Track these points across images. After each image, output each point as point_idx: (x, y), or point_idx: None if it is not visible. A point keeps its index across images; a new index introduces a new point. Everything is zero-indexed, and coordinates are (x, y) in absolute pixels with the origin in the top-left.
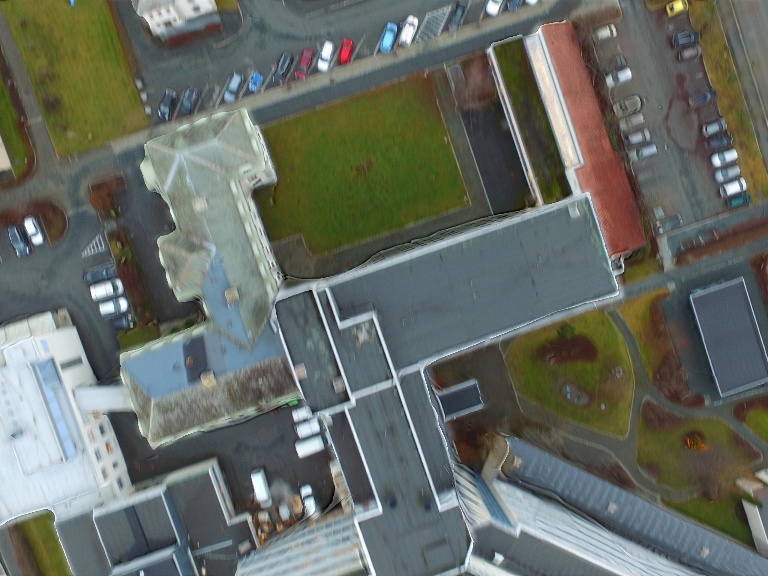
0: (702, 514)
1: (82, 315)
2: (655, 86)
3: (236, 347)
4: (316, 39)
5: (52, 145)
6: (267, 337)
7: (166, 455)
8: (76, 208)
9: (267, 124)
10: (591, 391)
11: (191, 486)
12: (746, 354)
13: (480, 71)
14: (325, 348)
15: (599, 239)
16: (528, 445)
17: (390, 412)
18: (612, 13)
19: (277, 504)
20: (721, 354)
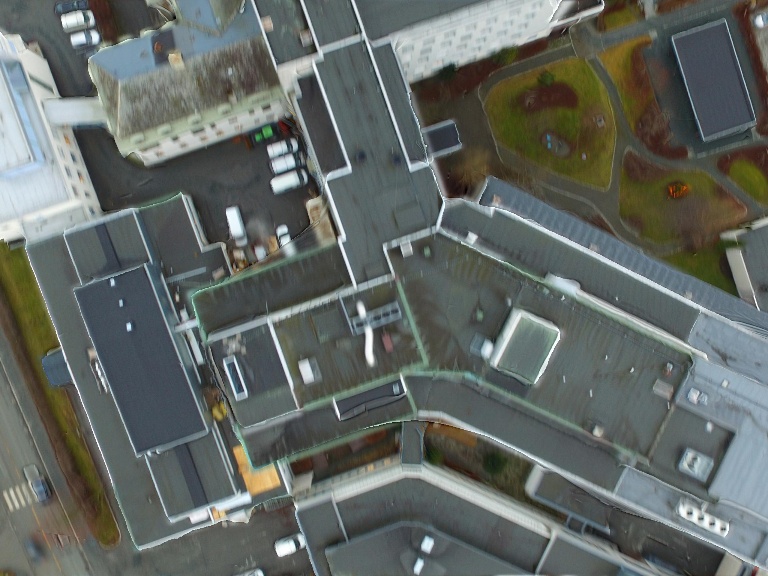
0: (686, 268)
1: (53, 49)
2: None
3: (205, 35)
4: None
5: None
6: (236, 23)
7: (140, 193)
8: None
9: None
10: (572, 140)
11: (164, 211)
12: (729, 97)
13: None
14: (292, 1)
15: None
16: (507, 185)
17: (359, 68)
18: None
19: (253, 244)
20: (703, 97)
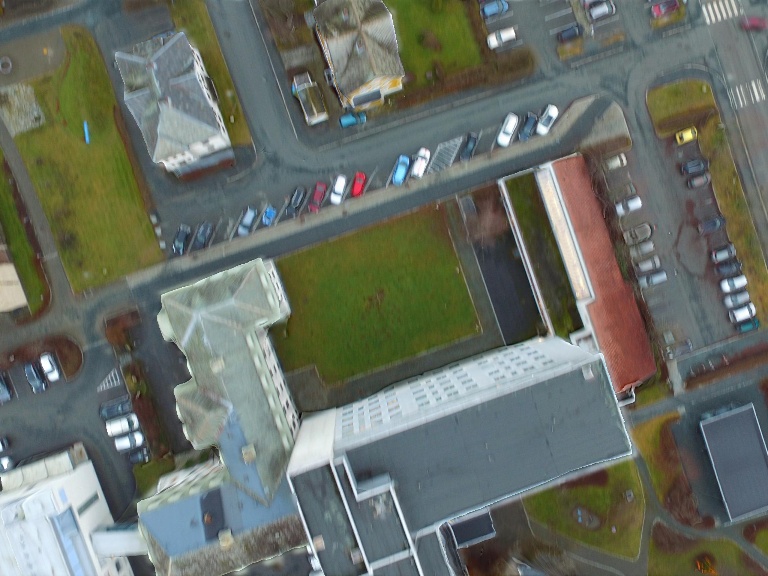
0: None
1: (98, 449)
2: (665, 213)
3: (253, 502)
4: (329, 172)
5: (68, 281)
6: (284, 493)
7: None
8: (91, 343)
9: (280, 256)
10: (602, 515)
11: None
12: (756, 480)
13: (491, 202)
14: (343, 520)
15: (613, 400)
16: (540, 574)
17: None
18: (622, 142)
19: None
20: (731, 480)
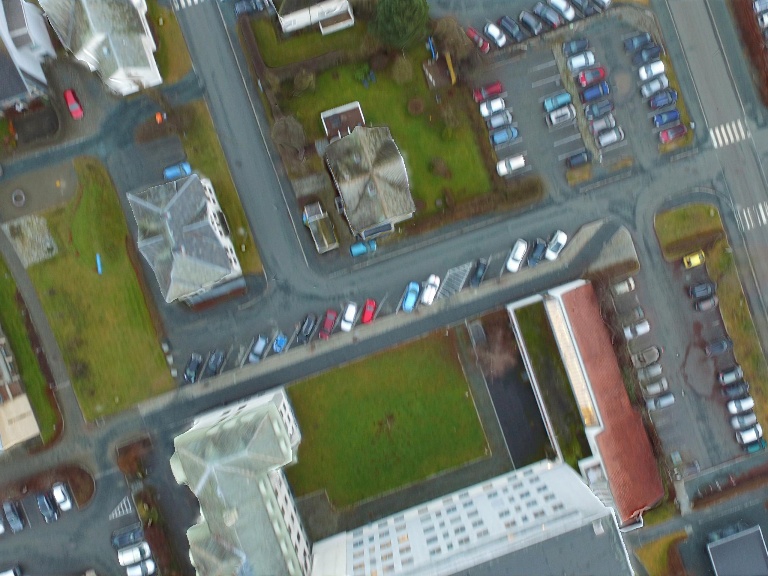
0: None
1: None
2: (672, 334)
3: None
4: (339, 299)
5: (80, 409)
6: None
7: None
8: (103, 471)
9: (291, 383)
10: None
11: None
12: None
13: (501, 327)
14: None
15: (623, 554)
16: None
17: None
18: (630, 265)
19: None
20: None
